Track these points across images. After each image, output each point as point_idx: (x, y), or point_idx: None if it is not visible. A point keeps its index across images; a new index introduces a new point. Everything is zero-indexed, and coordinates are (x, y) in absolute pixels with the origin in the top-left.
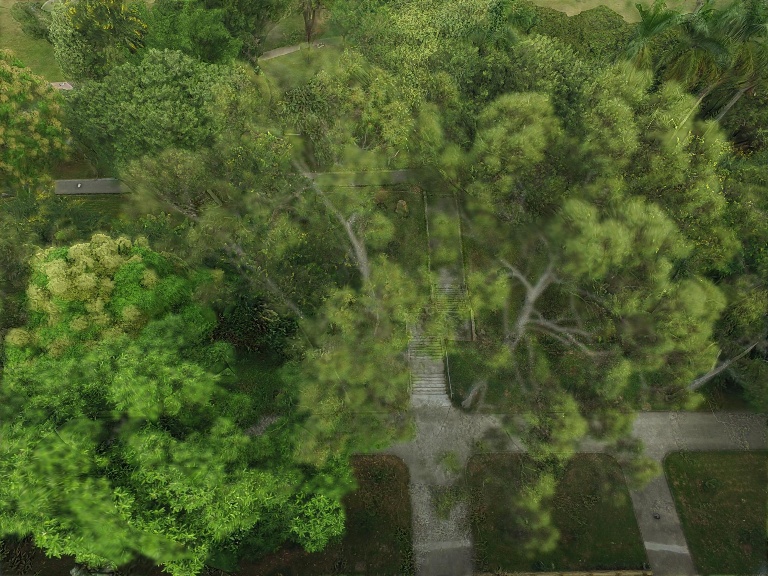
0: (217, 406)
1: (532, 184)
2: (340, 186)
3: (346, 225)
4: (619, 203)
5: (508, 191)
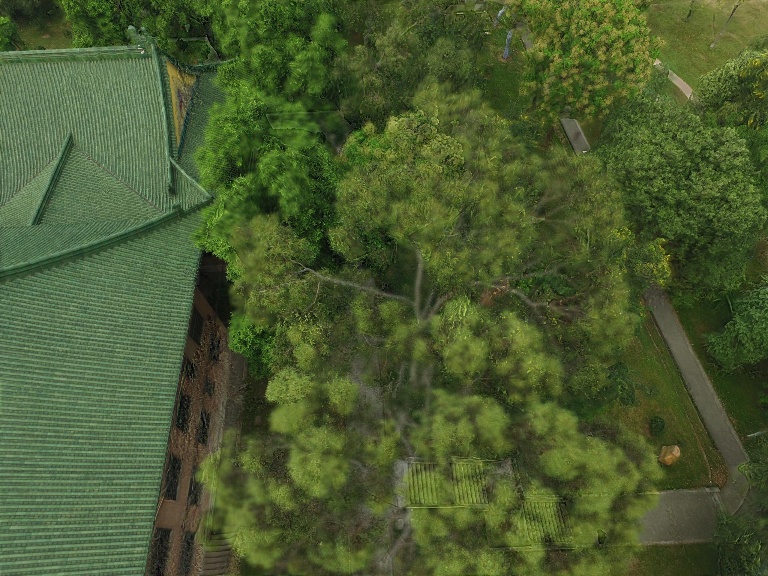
0: (382, 291)
1: None
2: (682, 376)
3: None
4: None
5: None
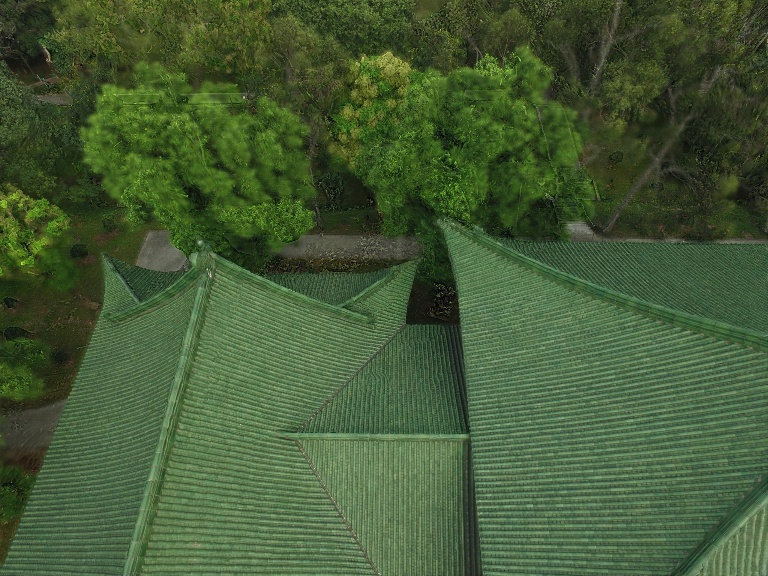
0: None
1: (646, 77)
2: None
3: (500, 104)
4: (725, 83)
5: (622, 88)
